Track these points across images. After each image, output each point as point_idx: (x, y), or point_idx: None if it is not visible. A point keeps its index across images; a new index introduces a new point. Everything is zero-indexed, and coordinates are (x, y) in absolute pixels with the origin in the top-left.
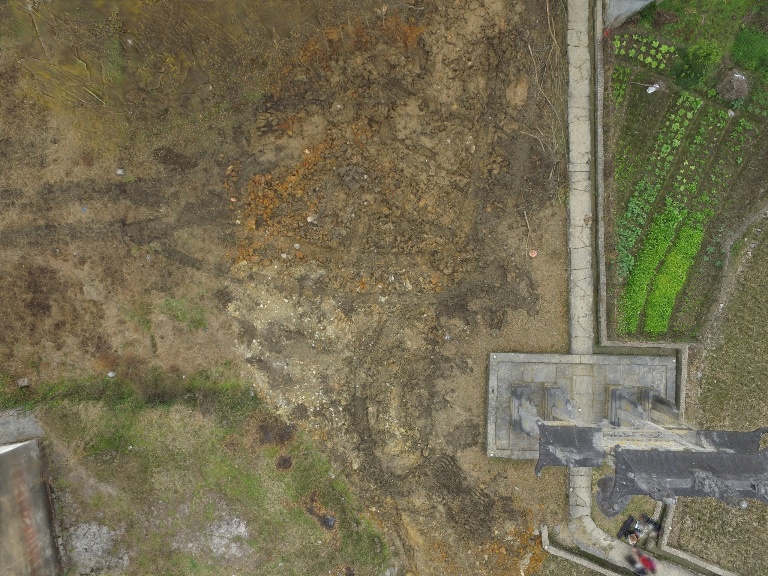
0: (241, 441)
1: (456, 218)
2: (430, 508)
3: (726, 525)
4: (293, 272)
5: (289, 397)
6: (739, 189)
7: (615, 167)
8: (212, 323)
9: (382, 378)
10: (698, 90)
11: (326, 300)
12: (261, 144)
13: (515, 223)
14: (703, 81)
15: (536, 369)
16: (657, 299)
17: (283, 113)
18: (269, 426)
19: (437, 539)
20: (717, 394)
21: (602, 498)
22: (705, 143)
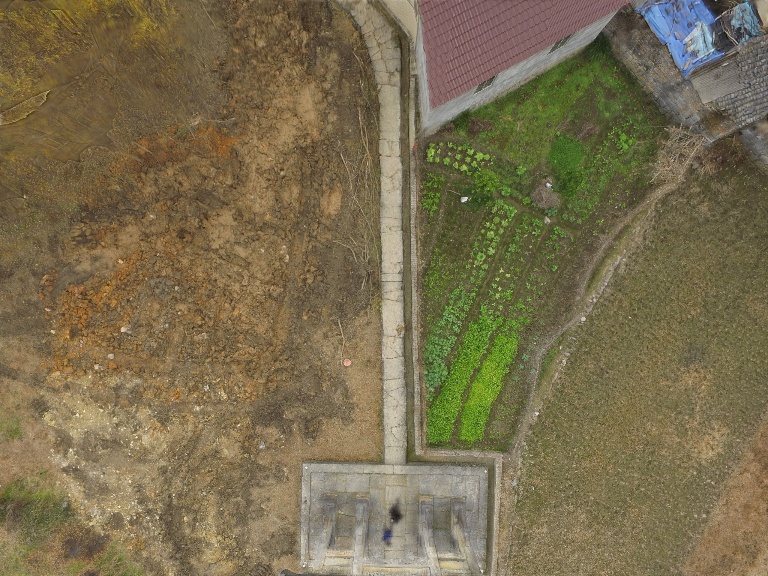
0: (45, 558)
1: (270, 328)
2: None
3: None
4: (108, 381)
5: (105, 507)
6: (555, 297)
7: (430, 275)
8: (28, 432)
9: (199, 486)
10: (514, 197)
11: (142, 409)
12: (75, 254)
13: (330, 332)
14: (518, 189)
15: (349, 479)
16: (472, 408)
17: (95, 223)
18: (78, 539)
19: None
20: (535, 501)
21: None
22: (520, 251)
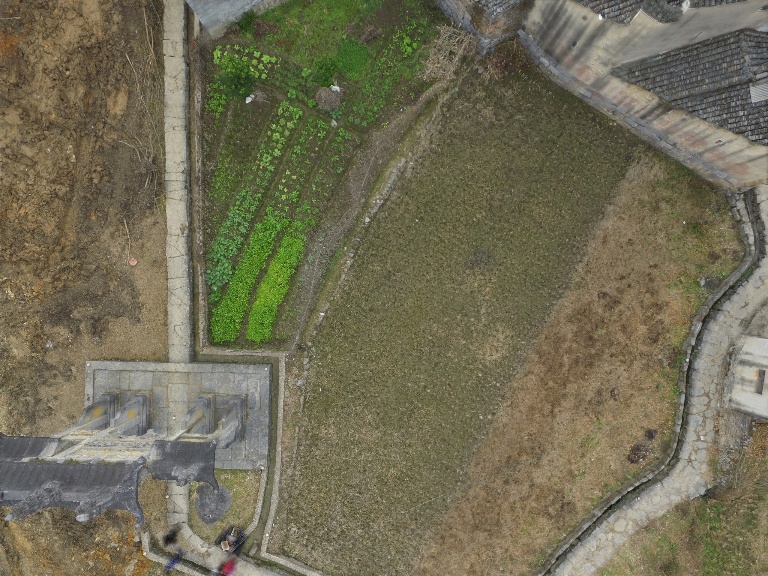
0: None
1: (56, 227)
2: (35, 515)
3: (332, 532)
4: None
5: None
6: (340, 199)
7: (217, 176)
8: None
9: None
10: (301, 100)
11: None
12: None
13: (117, 232)
14: (303, 91)
15: (133, 377)
16: (257, 308)
17: None
18: None
19: (42, 546)
20: (323, 402)
21: (199, 505)
22: (306, 153)
